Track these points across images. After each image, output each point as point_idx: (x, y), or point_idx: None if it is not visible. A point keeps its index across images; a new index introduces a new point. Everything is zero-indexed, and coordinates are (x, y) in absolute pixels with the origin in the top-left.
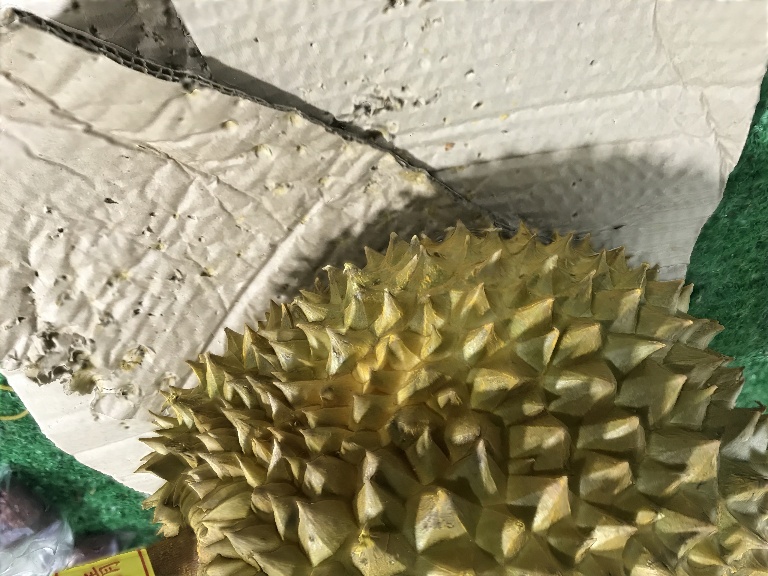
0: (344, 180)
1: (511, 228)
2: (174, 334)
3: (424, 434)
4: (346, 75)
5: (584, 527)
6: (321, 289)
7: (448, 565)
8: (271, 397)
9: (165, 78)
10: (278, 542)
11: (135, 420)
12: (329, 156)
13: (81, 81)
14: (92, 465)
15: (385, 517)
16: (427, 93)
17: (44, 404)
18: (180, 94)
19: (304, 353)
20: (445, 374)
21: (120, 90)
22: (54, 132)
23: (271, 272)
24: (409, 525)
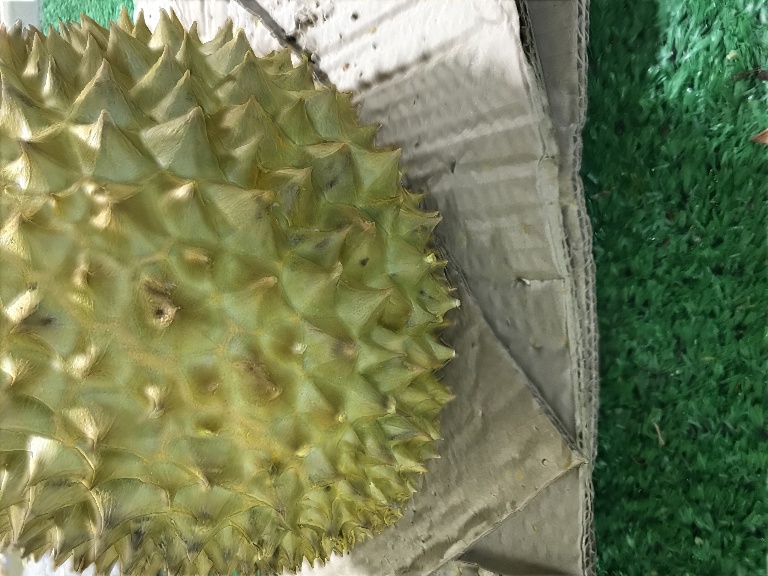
0: None
1: None
2: None
3: None
4: None
5: None
6: None
7: None
8: None
9: None
10: None
11: None
12: None
13: None
14: None
15: None
16: (326, 6)
17: None
18: None
19: None
20: None
21: None
22: None
23: None
24: None
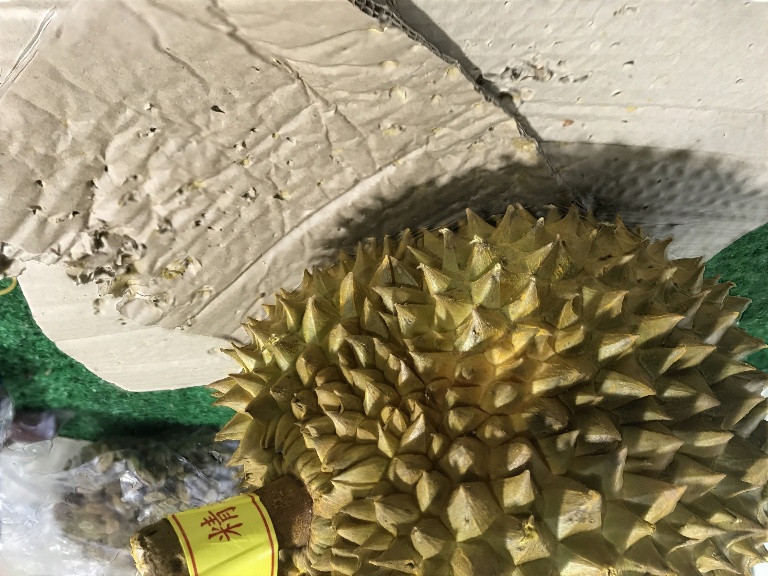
0: (457, 134)
1: (584, 207)
2: (226, 250)
3: (573, 433)
4: (518, 38)
5: (675, 523)
6: (411, 241)
7: (590, 556)
8: (404, 365)
9: (368, 12)
10: (418, 513)
11: None
12: (458, 110)
13: None
14: (70, 353)
15: (533, 506)
16: (580, 72)
17: (44, 291)
18: (367, 28)
19: (425, 320)
20: (586, 374)
21: (310, 11)
22: (195, 28)
23: (342, 205)
24: (552, 515)
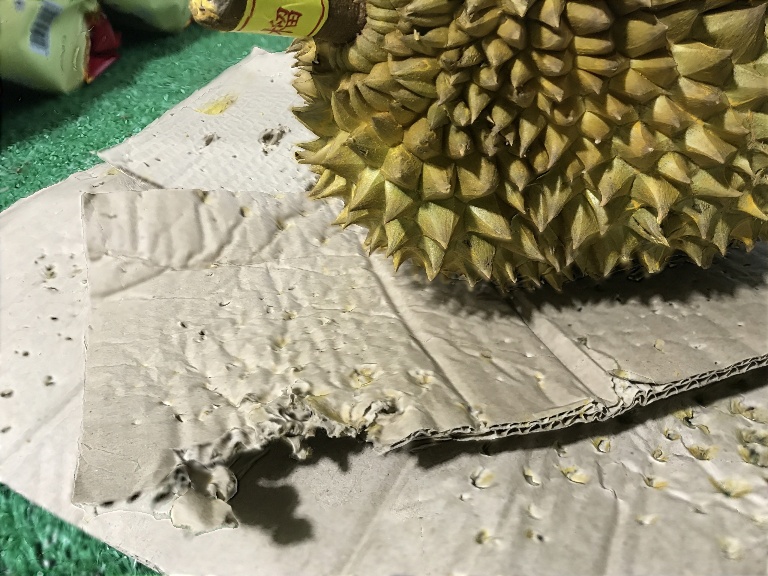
0: None
1: None
2: None
3: None
4: None
5: None
6: None
7: None
8: None
9: None
10: None
11: (530, 568)
12: None
13: (143, 219)
14: None
15: None
16: None
17: None
18: (199, 200)
19: None
20: None
21: (165, 210)
22: None
23: None
24: None
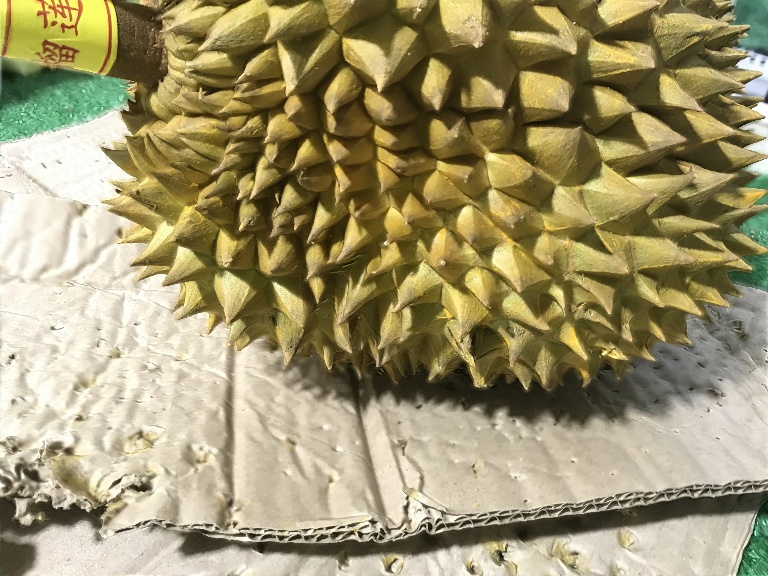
0: None
1: None
2: None
3: None
4: None
5: None
6: None
7: None
8: None
9: None
10: None
11: None
12: None
13: (7, 223)
14: None
15: None
16: None
17: None
18: (76, 212)
19: None
20: None
21: (34, 217)
22: None
23: None
24: None
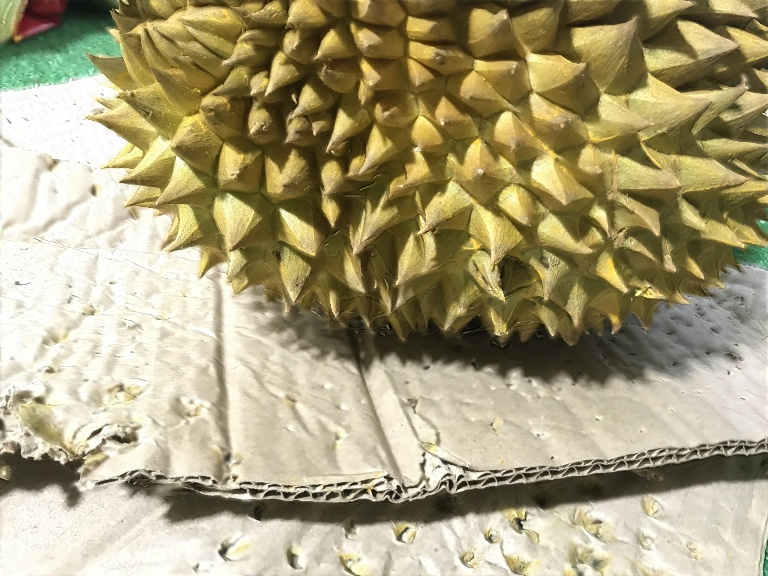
0: None
1: None
2: None
3: None
4: None
5: None
6: None
7: None
8: None
9: None
10: None
11: None
12: None
13: None
14: None
15: None
16: None
17: None
18: (45, 166)
19: None
20: None
21: None
22: None
23: None
24: None
